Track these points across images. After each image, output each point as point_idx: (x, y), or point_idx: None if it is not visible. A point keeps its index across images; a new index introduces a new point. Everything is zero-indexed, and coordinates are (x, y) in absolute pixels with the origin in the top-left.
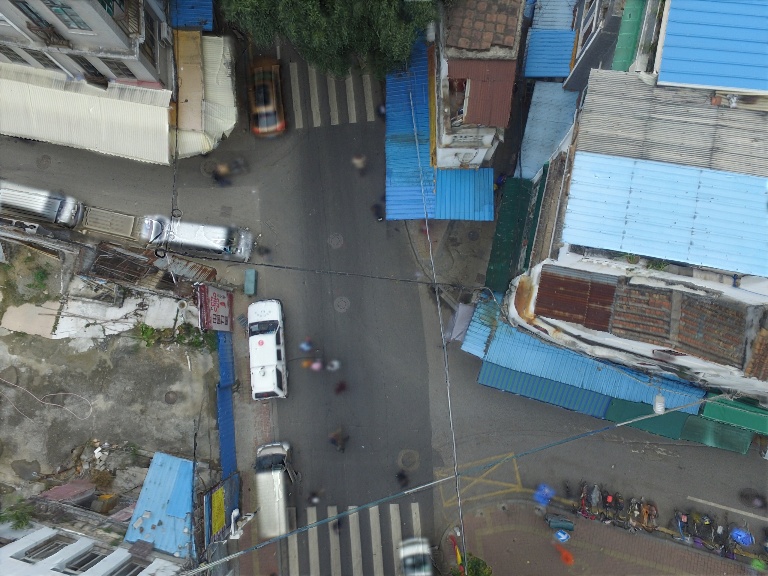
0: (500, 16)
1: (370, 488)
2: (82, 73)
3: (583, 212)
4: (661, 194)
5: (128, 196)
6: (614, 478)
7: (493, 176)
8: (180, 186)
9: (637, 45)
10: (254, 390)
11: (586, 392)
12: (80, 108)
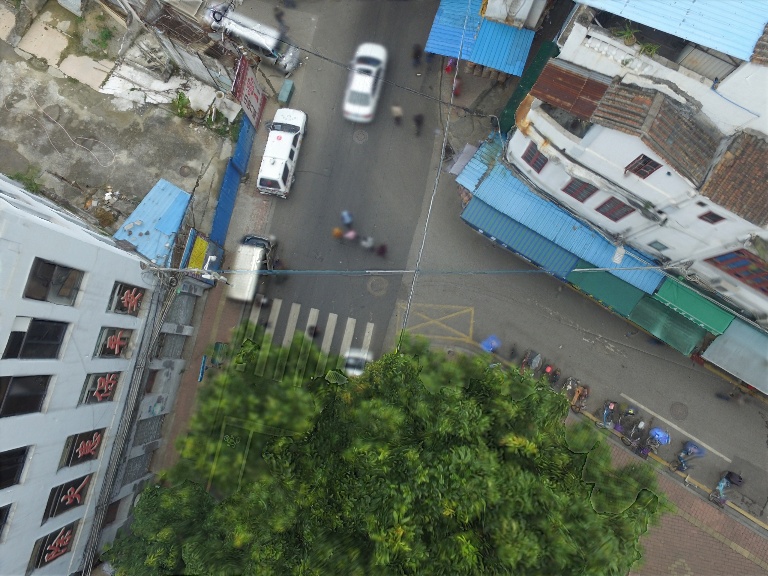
0: None
1: (335, 298)
2: None
3: None
4: None
5: None
6: (558, 356)
7: (533, 39)
8: None
9: None
10: (261, 174)
11: (556, 250)
12: None
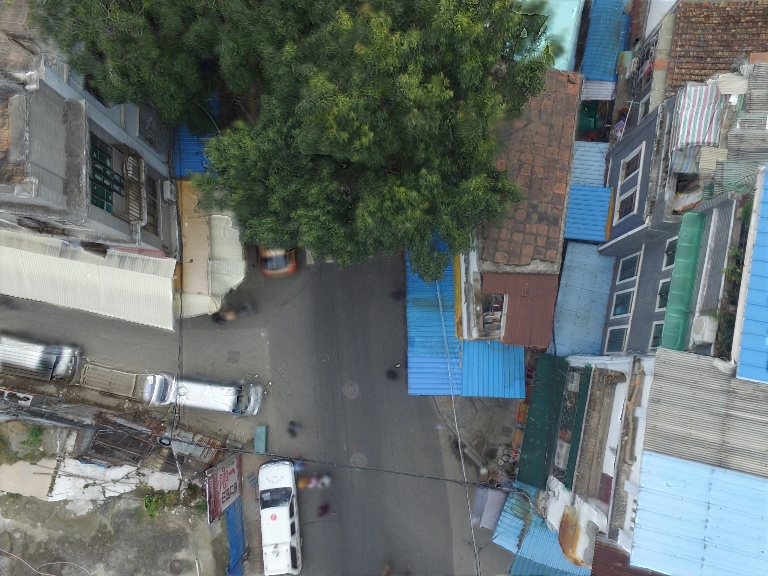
0: (541, 227)
1: None
2: (79, 241)
3: (654, 528)
4: (745, 514)
5: (129, 339)
6: None
7: (524, 348)
8: (184, 328)
9: (697, 277)
10: (267, 573)
11: None
12: (77, 273)
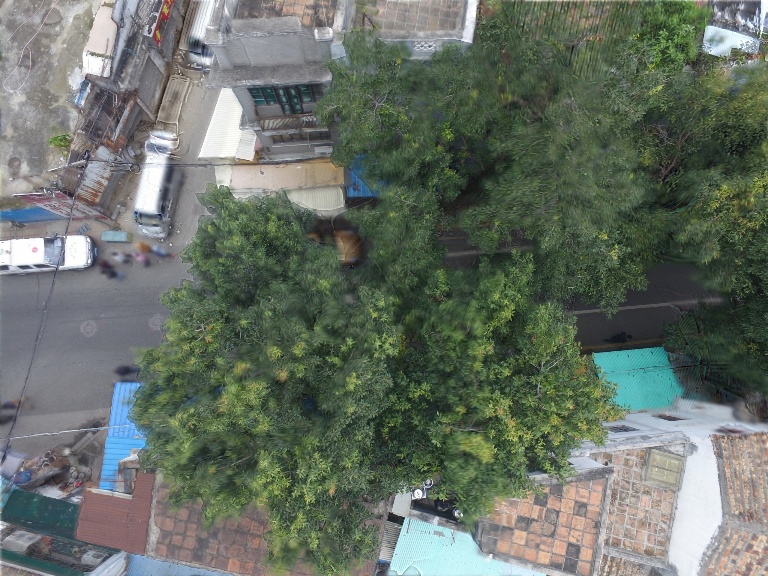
0: (192, 541)
1: None
2: None
3: None
4: None
5: None
6: None
7: None
8: None
9: None
10: None
11: None
12: None
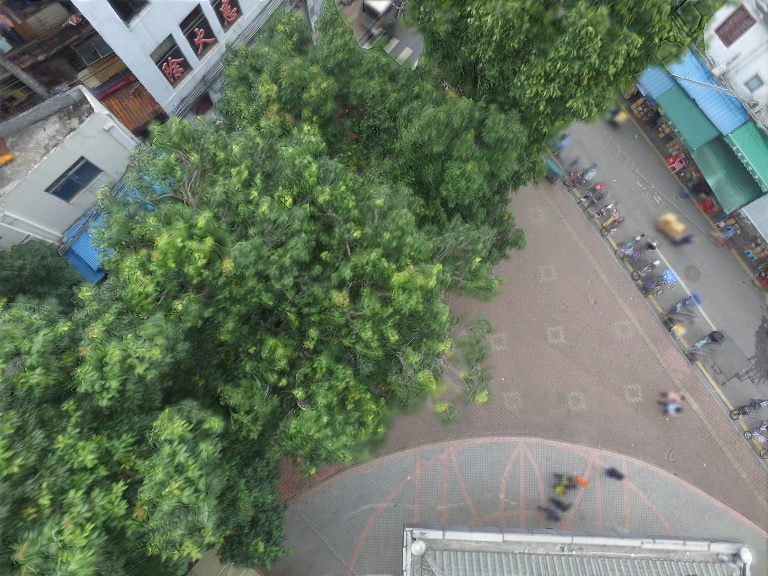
0: None
1: None
2: None
3: None
4: None
5: None
6: (610, 186)
7: None
8: None
9: None
10: None
11: None
12: None
